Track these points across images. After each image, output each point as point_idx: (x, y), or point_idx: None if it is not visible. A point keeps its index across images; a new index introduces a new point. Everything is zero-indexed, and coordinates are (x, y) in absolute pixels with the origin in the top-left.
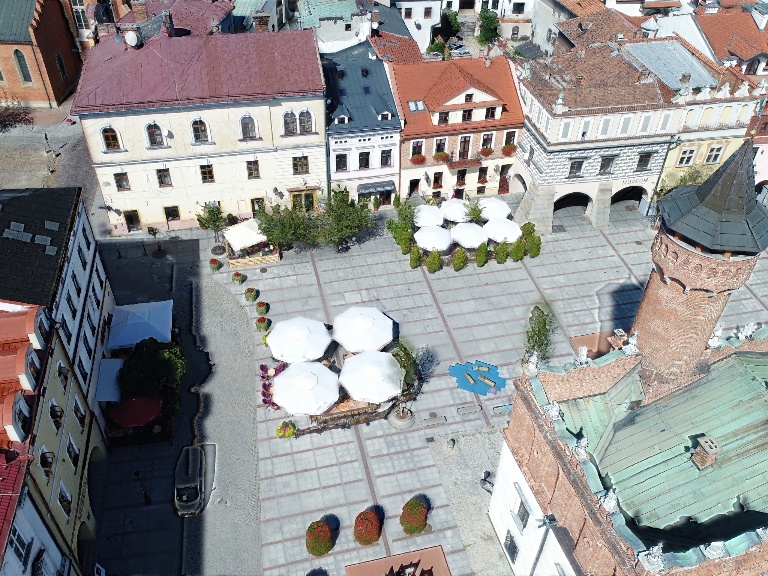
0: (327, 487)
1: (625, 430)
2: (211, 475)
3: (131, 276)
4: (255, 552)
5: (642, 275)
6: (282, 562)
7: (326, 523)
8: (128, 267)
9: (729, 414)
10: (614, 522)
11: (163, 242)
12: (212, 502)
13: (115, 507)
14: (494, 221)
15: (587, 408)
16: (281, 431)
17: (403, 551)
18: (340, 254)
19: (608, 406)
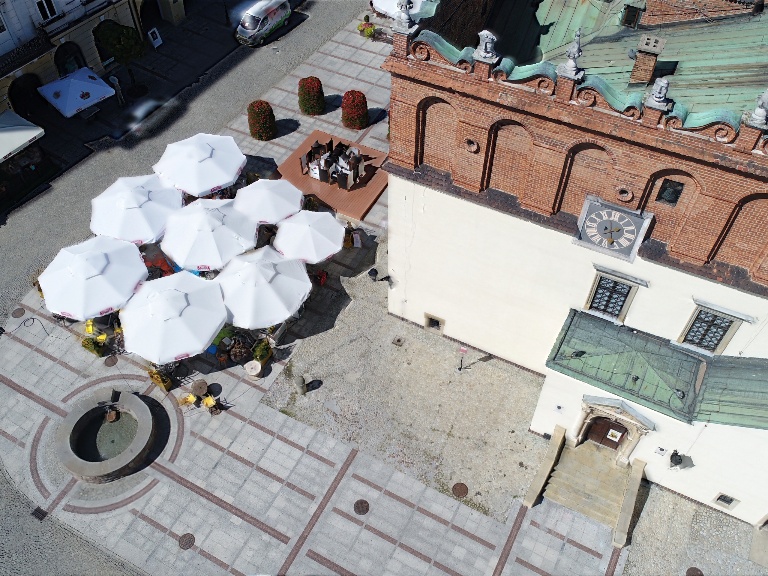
0: (360, 80)
1: (600, 44)
2: (286, 31)
3: None
4: (265, 87)
5: None
6: (276, 103)
7: (333, 99)
8: None
9: (731, 52)
10: (422, 5)
11: None
12: (269, 46)
13: (206, 17)
14: None
15: (576, 7)
16: (362, 25)
17: (371, 146)
18: None
19: (604, 16)
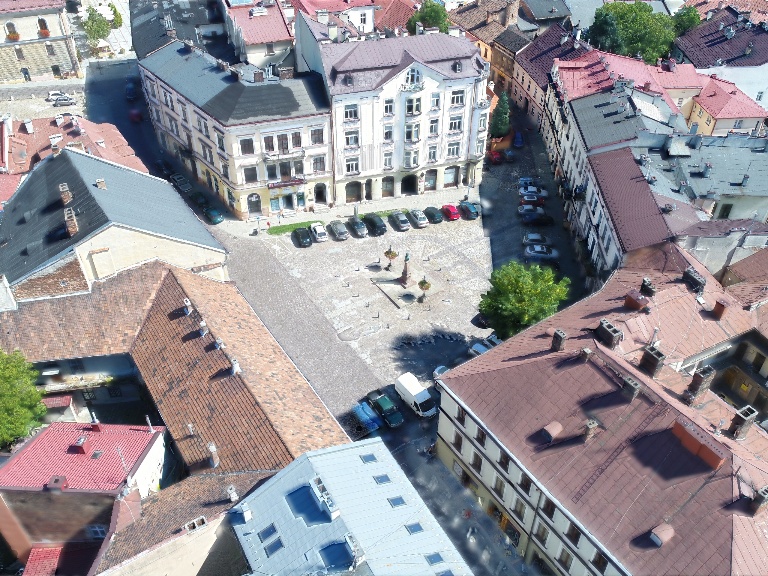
0: None
1: None
2: None
3: (117, 70)
4: None
5: (126, 1)
6: None
7: None
8: (110, 72)
9: None
10: None
11: (91, 68)
12: None
13: None
14: (98, 8)
15: None
16: None
17: None
18: (106, 39)
19: None
